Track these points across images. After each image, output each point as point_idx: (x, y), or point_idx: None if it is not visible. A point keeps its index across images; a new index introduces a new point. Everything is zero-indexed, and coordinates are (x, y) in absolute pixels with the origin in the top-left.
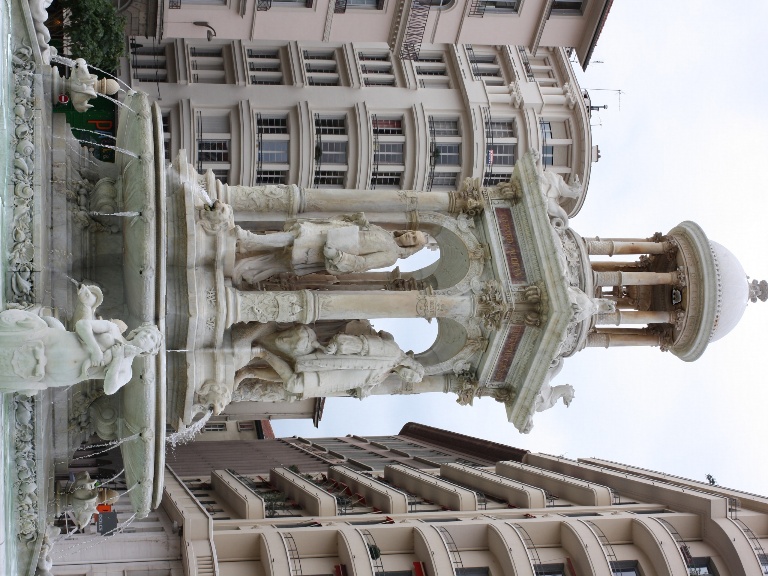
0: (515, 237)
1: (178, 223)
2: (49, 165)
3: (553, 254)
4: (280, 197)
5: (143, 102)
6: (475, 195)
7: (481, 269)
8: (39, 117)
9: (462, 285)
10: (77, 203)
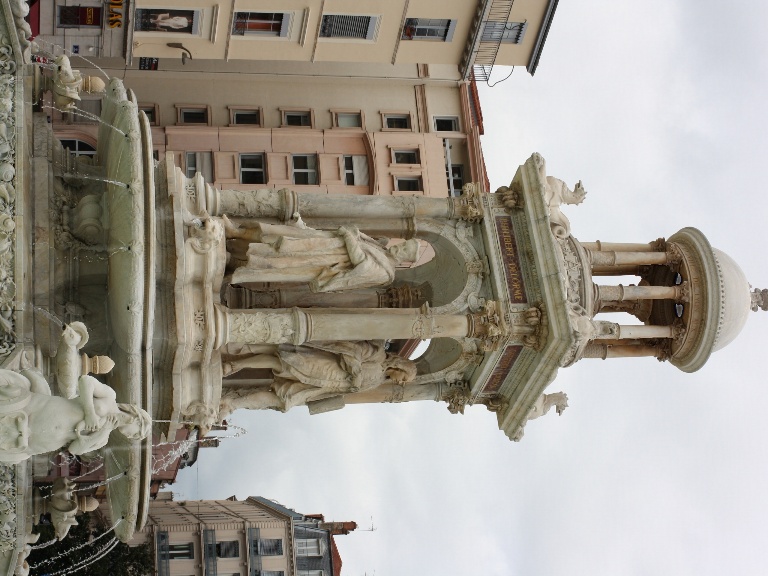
0: None
1: None
2: None
3: (528, 407)
4: None
5: (131, 502)
6: None
7: None
8: (21, 499)
9: (439, 373)
10: None
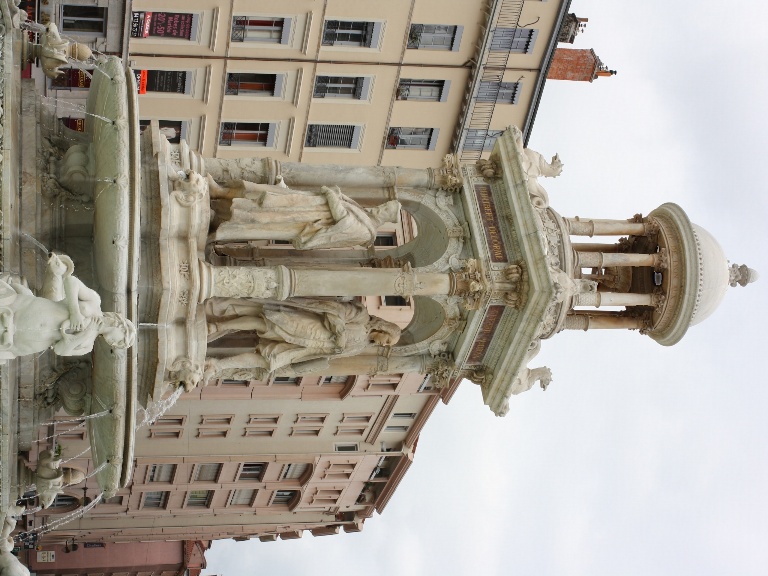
0: (494, 329)
1: (146, 381)
2: (16, 389)
3: (512, 374)
4: (266, 297)
5: (116, 443)
6: (475, 298)
7: (448, 335)
8: (6, 441)
9: (422, 344)
10: (44, 397)
